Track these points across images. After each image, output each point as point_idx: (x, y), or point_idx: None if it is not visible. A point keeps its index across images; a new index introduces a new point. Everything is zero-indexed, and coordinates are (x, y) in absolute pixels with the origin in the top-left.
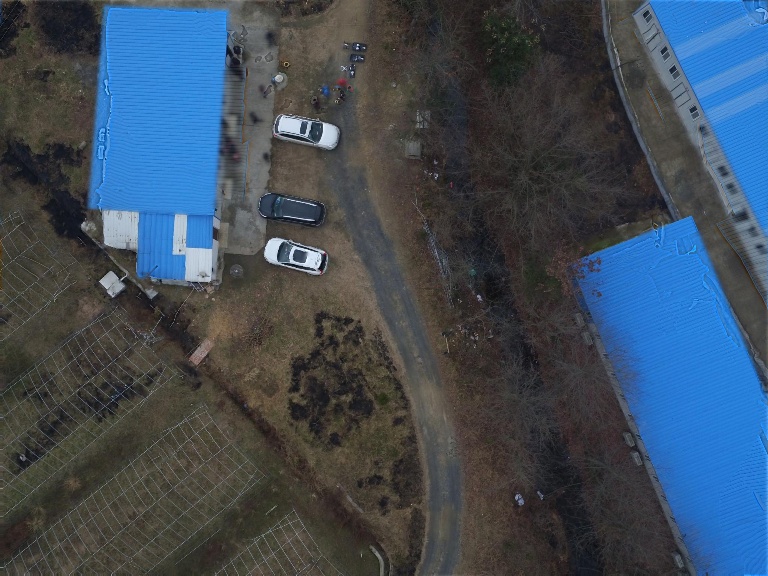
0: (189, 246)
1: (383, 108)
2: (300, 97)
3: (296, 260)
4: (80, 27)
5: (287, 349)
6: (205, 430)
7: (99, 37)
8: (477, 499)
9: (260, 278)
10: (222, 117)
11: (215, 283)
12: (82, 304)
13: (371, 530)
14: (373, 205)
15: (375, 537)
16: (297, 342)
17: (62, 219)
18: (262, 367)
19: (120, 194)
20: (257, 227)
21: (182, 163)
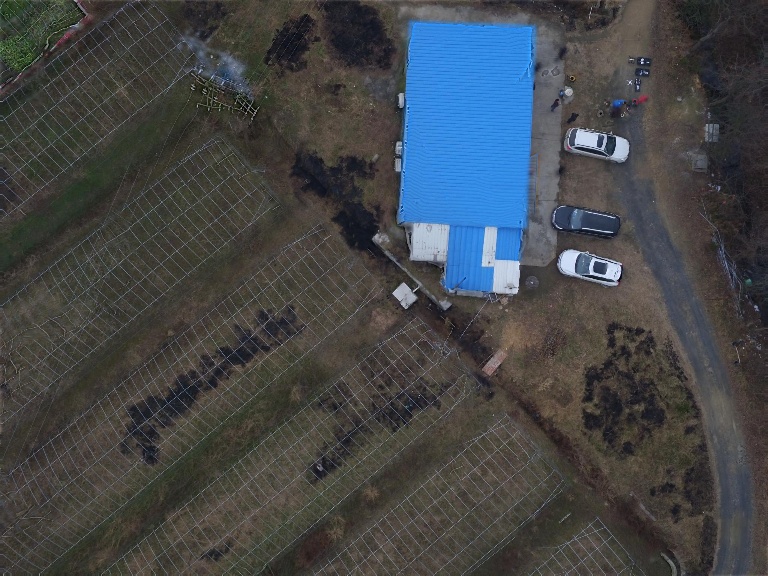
0: (498, 258)
1: (668, 121)
2: (586, 111)
3: (597, 272)
4: (369, 41)
5: (580, 359)
6: (515, 440)
7: (388, 51)
8: (767, 506)
9: (551, 289)
10: (509, 130)
11: (510, 294)
12: (375, 315)
13: (663, 538)
14: (661, 217)
15: (666, 545)
16: (590, 352)
17: (352, 231)
18: (556, 377)
19: (416, 206)
20: (548, 239)
21: (474, 176)
